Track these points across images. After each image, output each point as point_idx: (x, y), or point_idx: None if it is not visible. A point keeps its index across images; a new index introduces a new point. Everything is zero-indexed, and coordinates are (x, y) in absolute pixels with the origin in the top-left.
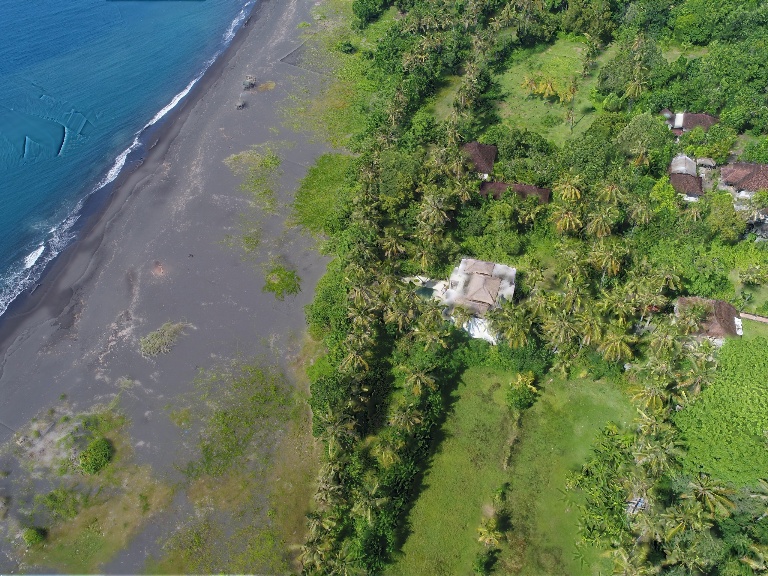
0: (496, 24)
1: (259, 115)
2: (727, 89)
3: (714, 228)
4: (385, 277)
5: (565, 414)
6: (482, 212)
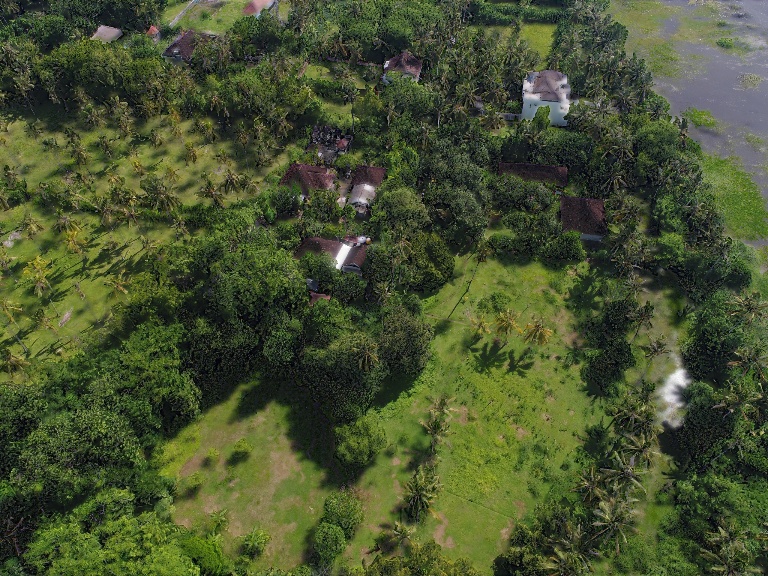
0: None
1: None
2: None
3: None
4: None
5: None
6: None
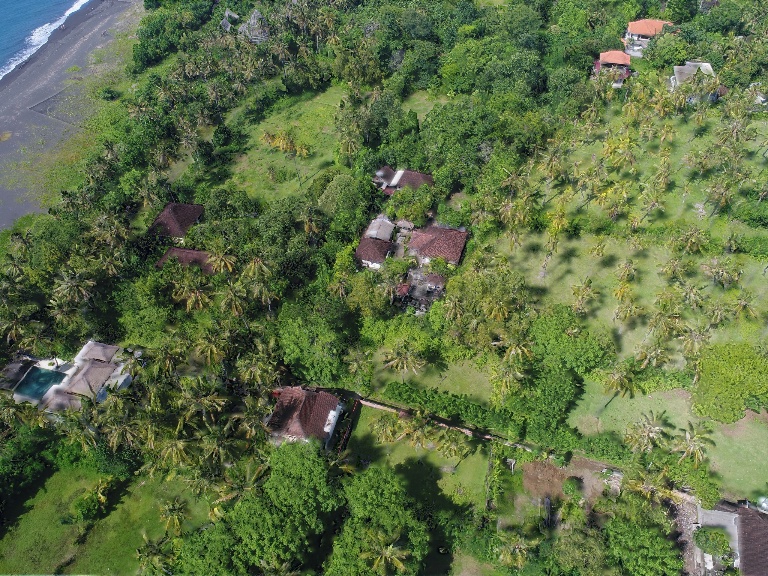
0: (247, 73)
1: None
2: (442, 146)
3: (352, 305)
4: None
5: (140, 525)
6: None
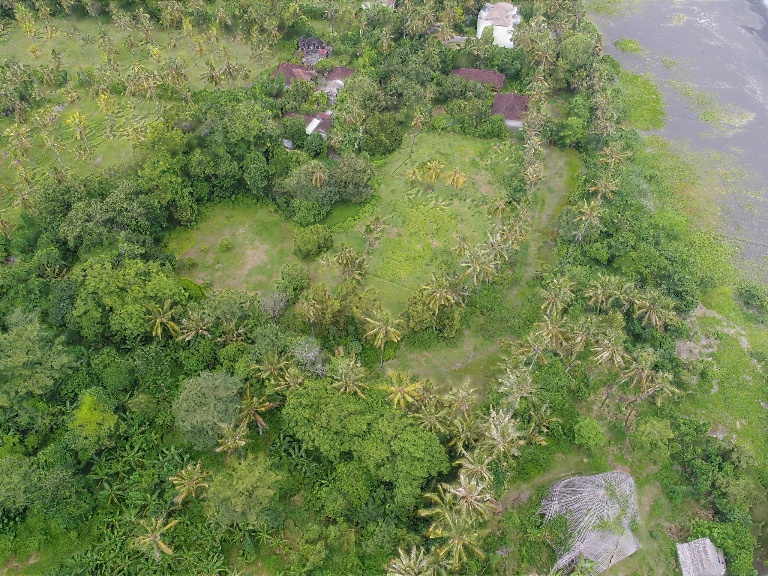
0: None
1: None
2: None
3: None
4: None
5: None
6: None
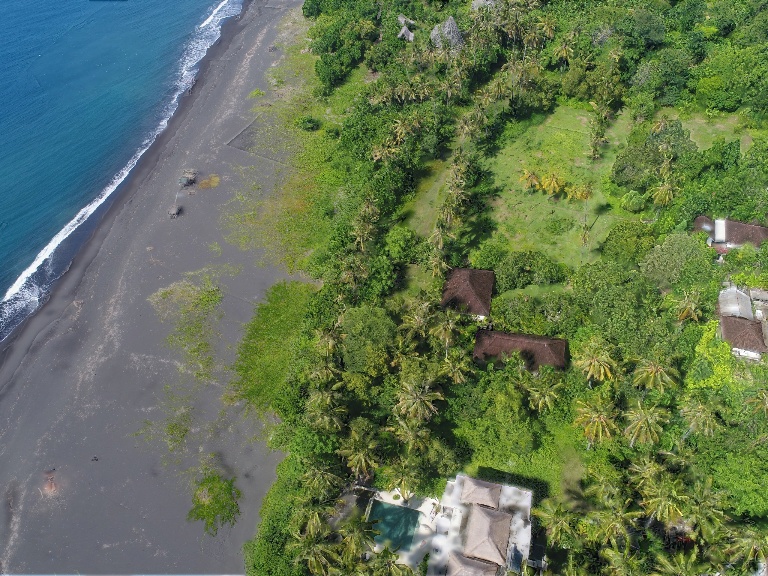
0: (485, 98)
1: (198, 226)
2: None
3: None
4: (349, 535)
5: None
6: (480, 391)
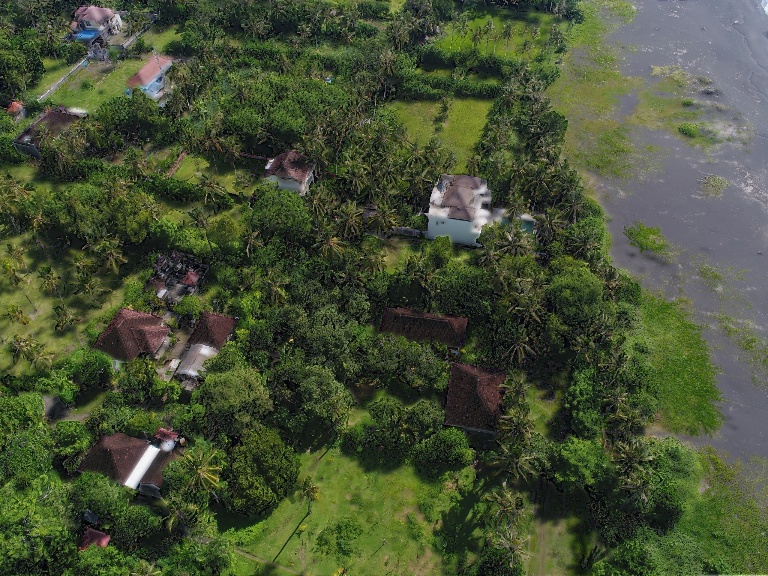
0: None
1: None
2: None
3: None
4: None
5: None
6: None
